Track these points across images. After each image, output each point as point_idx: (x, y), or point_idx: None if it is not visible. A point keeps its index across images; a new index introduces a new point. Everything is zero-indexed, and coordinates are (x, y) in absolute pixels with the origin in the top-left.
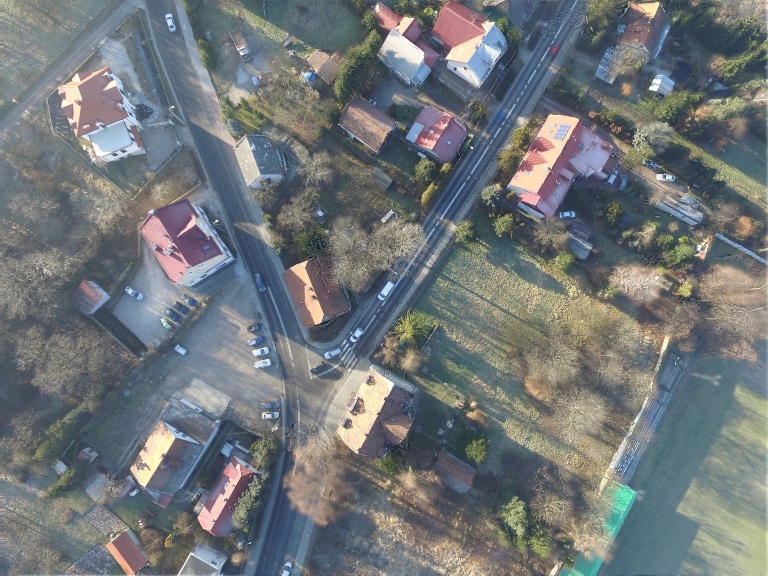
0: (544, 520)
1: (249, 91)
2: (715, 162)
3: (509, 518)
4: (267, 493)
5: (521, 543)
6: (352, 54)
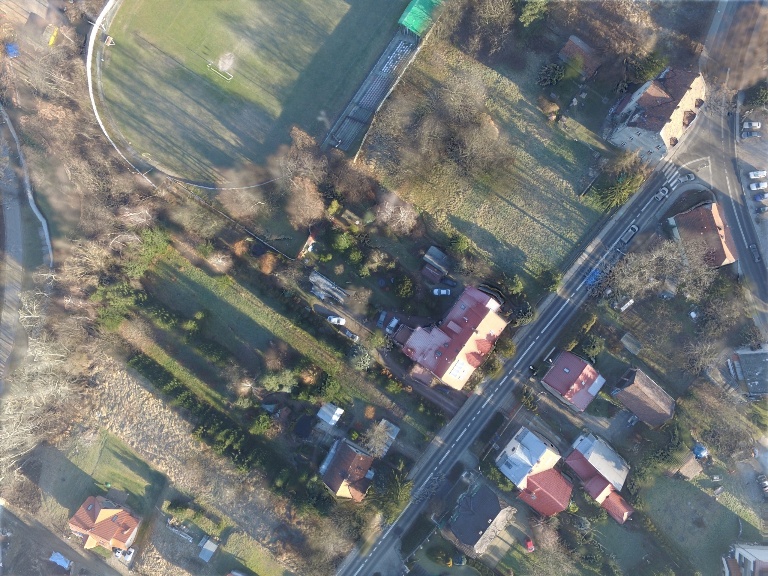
0: (508, 0)
1: (760, 444)
2: (280, 333)
3: (543, 5)
4: (764, 52)
5: None
6: (654, 472)
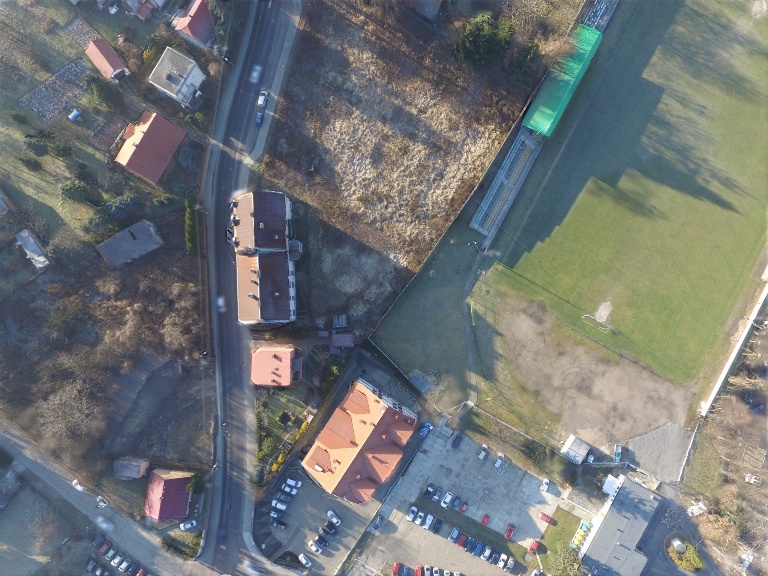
0: (510, 24)
1: None
2: None
3: None
4: (243, 8)
5: (487, 31)
6: None
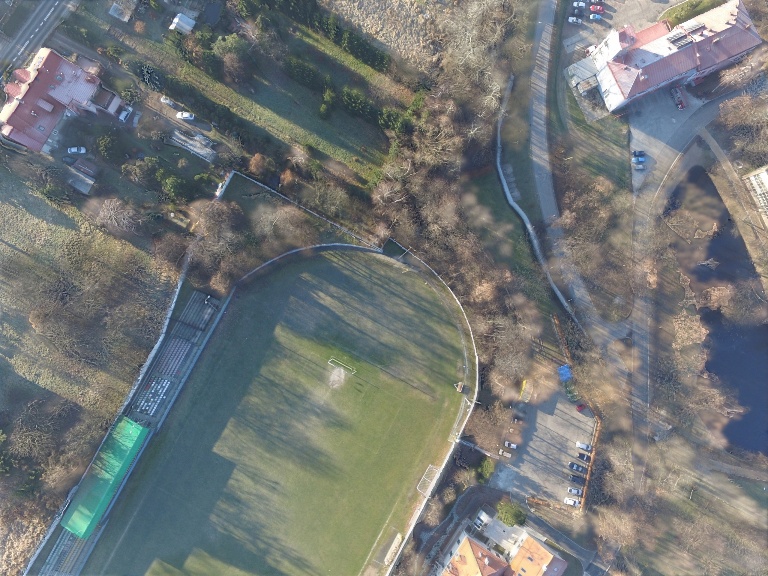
0: (13, 451)
1: None
2: (246, 102)
3: None
4: None
5: None
6: None
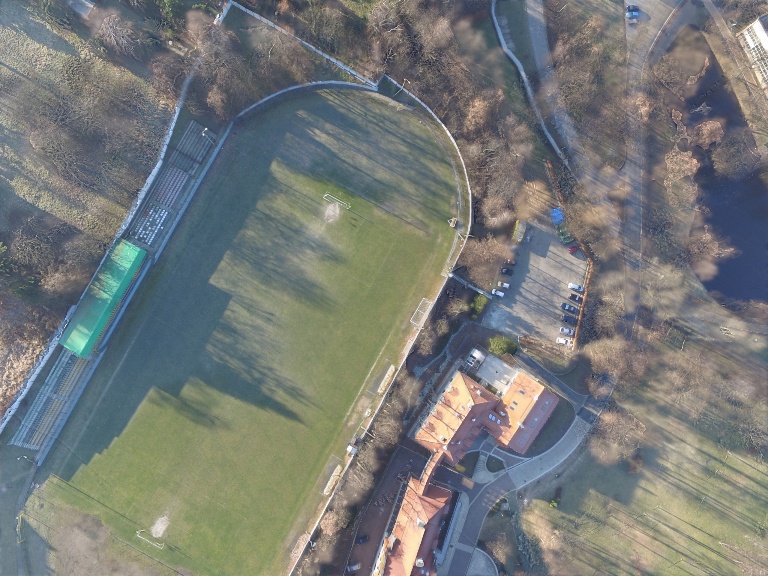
0: (13, 257)
1: None
2: None
3: None
4: None
5: None
6: None
